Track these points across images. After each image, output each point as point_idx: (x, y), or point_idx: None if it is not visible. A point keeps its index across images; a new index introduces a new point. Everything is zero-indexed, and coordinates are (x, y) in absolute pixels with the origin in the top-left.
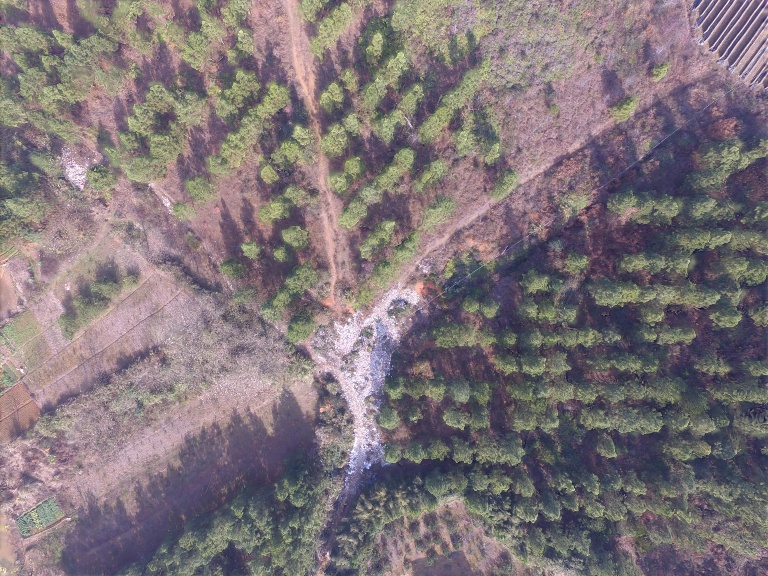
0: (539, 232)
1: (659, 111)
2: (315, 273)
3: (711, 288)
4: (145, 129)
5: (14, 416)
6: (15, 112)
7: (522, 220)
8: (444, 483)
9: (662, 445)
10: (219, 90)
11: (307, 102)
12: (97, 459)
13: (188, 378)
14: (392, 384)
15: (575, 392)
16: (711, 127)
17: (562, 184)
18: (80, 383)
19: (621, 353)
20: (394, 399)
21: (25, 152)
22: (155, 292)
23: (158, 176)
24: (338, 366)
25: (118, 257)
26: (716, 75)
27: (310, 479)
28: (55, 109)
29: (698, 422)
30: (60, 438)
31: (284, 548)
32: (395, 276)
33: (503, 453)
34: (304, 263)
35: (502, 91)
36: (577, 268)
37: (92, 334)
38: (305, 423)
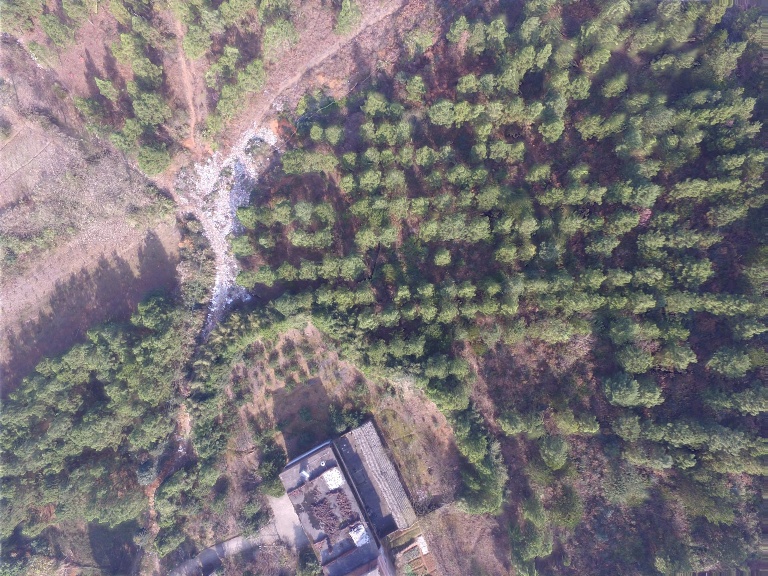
0: (385, 67)
1: None
2: (168, 108)
3: None
4: None
5: None
6: None
7: (370, 58)
8: (290, 300)
9: (494, 252)
10: None
11: None
12: None
13: (57, 226)
14: (239, 207)
15: (410, 204)
16: None
17: (408, 22)
18: None
19: None
20: (250, 232)
21: None
22: (25, 144)
23: (23, 28)
24: (200, 206)
25: None
26: None
27: (166, 306)
28: None
29: (521, 221)
30: None
31: (137, 369)
32: (250, 115)
33: (342, 264)
34: (153, 94)
35: None
36: (418, 96)
37: None
38: (170, 264)
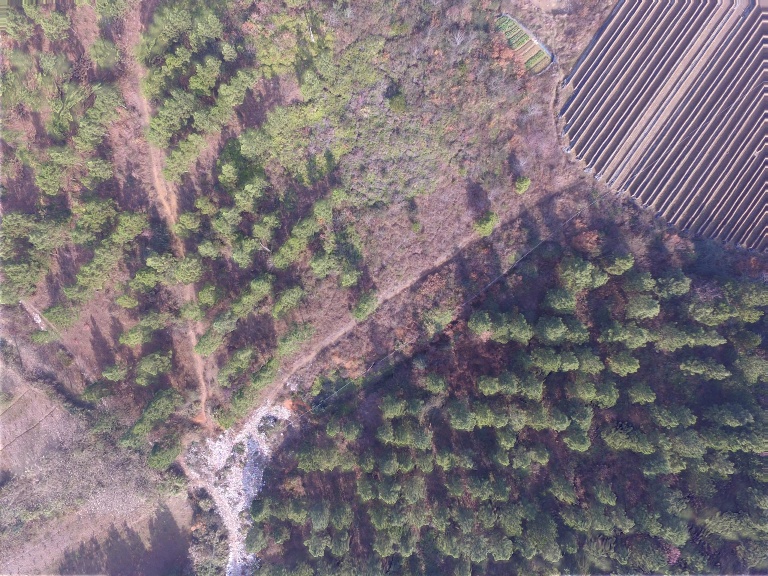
0: (403, 349)
1: (525, 222)
2: (179, 397)
3: (563, 412)
4: (5, 254)
5: None
6: None
7: (388, 336)
8: None
9: (516, 569)
10: (83, 209)
11: (170, 222)
12: None
13: (65, 494)
14: (254, 510)
15: (431, 518)
16: (575, 239)
17: (427, 300)
18: None
19: (476, 478)
20: None
21: None
22: (30, 408)
23: (25, 296)
24: (212, 481)
25: None
26: (583, 183)
27: None
28: None
29: (546, 551)
30: None
31: None
32: (264, 393)
33: None
34: (164, 391)
35: (363, 209)
36: None
37: None
38: (181, 537)
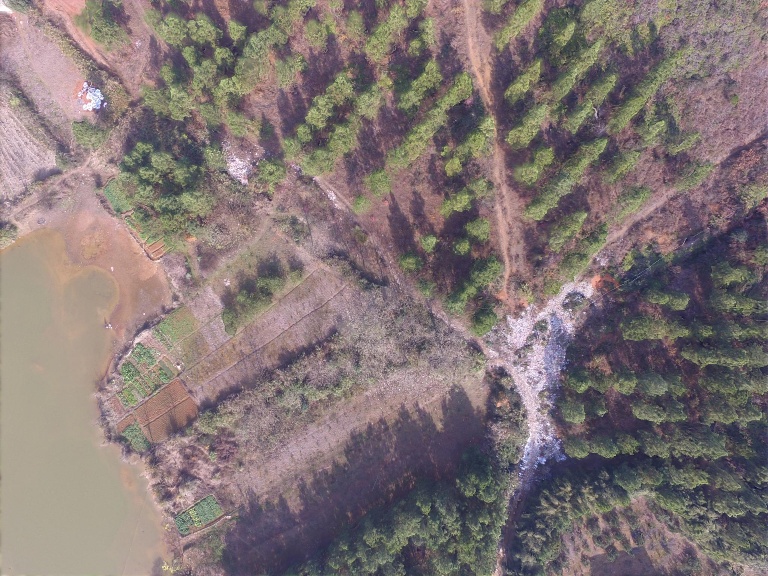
0: (720, 224)
1: None
2: None
3: None
4: (322, 122)
5: (171, 413)
6: (186, 105)
7: (701, 212)
8: (637, 478)
9: None
10: (390, 82)
11: (482, 94)
12: (258, 456)
13: (354, 373)
14: (582, 378)
15: None
16: None
17: (742, 175)
18: (240, 379)
19: None
20: (572, 393)
21: (189, 146)
22: (319, 287)
23: (327, 169)
24: (511, 360)
25: (280, 252)
26: None
27: (494, 474)
28: (225, 102)
29: None
30: (220, 435)
31: (473, 544)
32: None
33: (703, 447)
34: (491, 256)
35: (683, 81)
36: (765, 259)
37: (253, 330)
38: (476, 418)
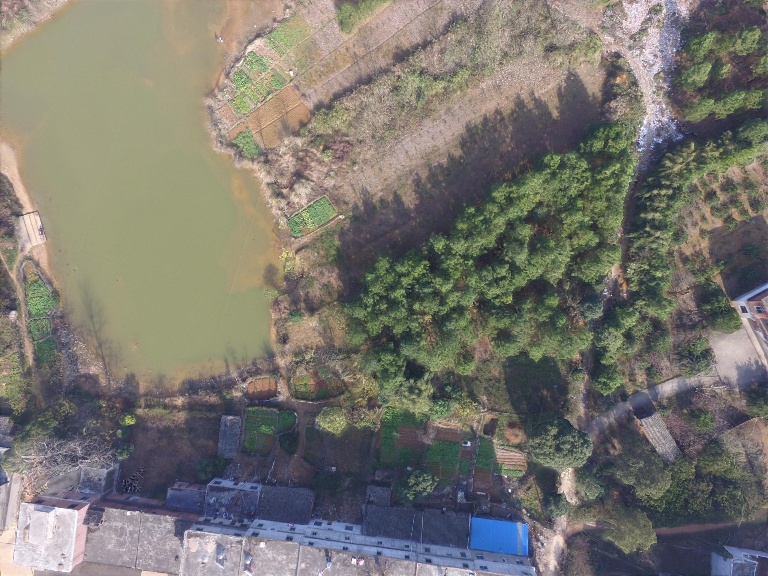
0: None
1: None
2: None
3: None
4: None
5: (283, 119)
6: None
7: None
8: None
9: None
10: None
11: None
12: (372, 154)
13: (470, 66)
14: None
15: None
16: None
17: None
18: (354, 81)
19: None
20: None
21: None
22: None
23: None
24: (626, 45)
25: None
26: None
27: None
28: None
29: None
30: (334, 135)
31: (603, 194)
32: None
33: None
34: None
35: None
36: None
37: (367, 31)
38: (591, 104)
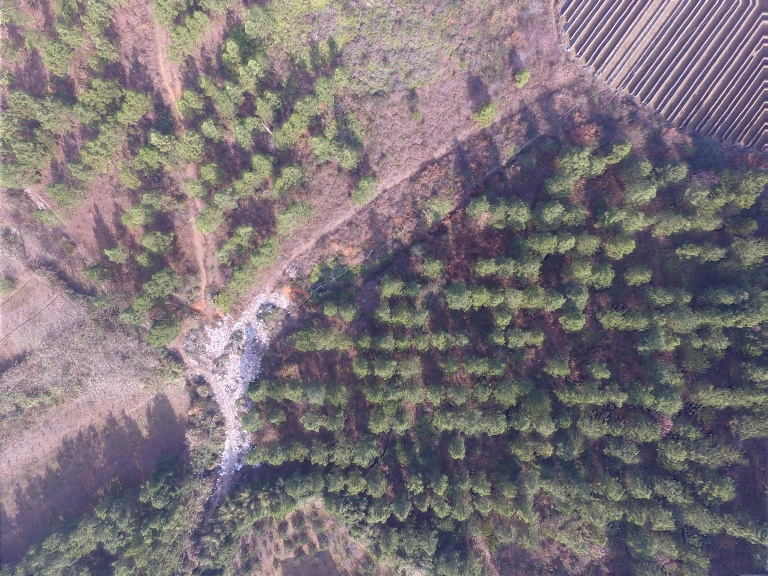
0: (402, 237)
1: (524, 117)
2: (179, 278)
3: (559, 292)
4: (11, 135)
5: None
6: None
7: (387, 225)
8: (301, 484)
9: (510, 446)
10: None
11: (174, 108)
12: None
13: (65, 381)
14: (251, 387)
15: (426, 395)
16: (573, 133)
17: (426, 189)
18: None
19: (471, 356)
20: (261, 402)
21: None
22: (32, 296)
23: (30, 182)
24: (209, 369)
25: None
26: (582, 81)
27: (175, 481)
28: None
29: (539, 424)
30: None
31: (146, 549)
32: (263, 280)
33: (355, 455)
34: (164, 268)
35: (365, 97)
36: (435, 272)
37: None
38: (178, 425)
